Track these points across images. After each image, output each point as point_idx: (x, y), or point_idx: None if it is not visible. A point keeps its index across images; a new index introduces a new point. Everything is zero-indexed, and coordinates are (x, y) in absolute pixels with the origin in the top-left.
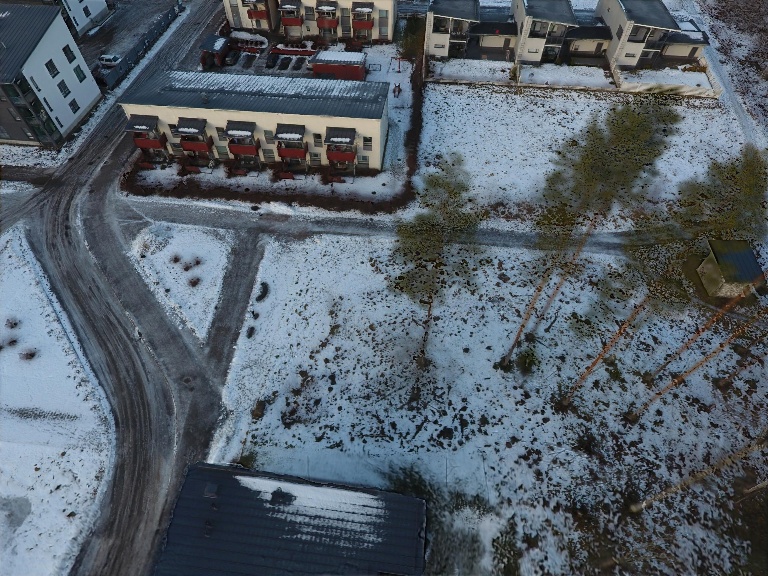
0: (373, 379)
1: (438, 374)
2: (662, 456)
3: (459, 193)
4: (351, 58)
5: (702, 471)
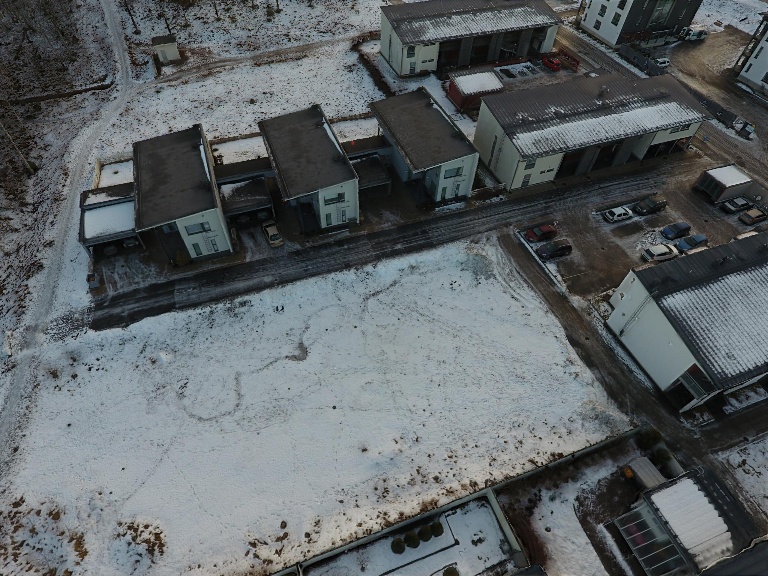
0: (328, 1)
1: (304, 5)
2: (218, 4)
3: (326, 59)
4: (467, 80)
5: None
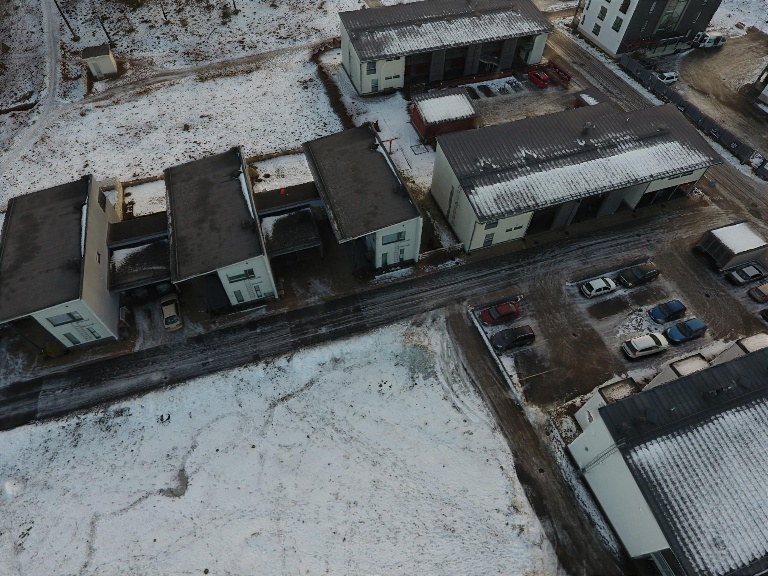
0: None
1: None
2: (170, 4)
3: (280, 72)
4: (432, 105)
5: (155, 5)
